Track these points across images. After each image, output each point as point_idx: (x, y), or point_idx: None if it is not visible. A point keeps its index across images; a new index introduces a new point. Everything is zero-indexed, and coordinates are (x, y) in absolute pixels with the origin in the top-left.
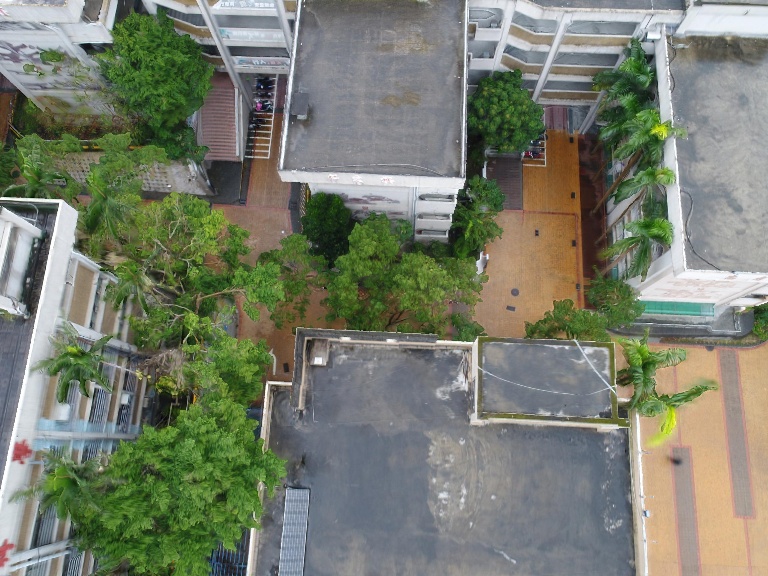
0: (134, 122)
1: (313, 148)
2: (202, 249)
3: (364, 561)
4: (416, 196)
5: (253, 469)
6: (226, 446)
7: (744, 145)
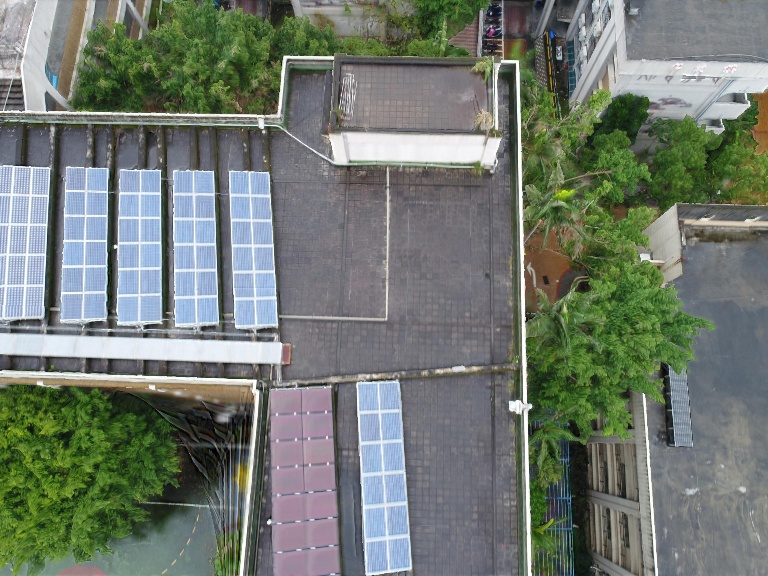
0: (389, 42)
1: (649, 41)
2: (583, 128)
3: (748, 425)
4: (719, 96)
5: (676, 326)
6: (668, 299)
7: None
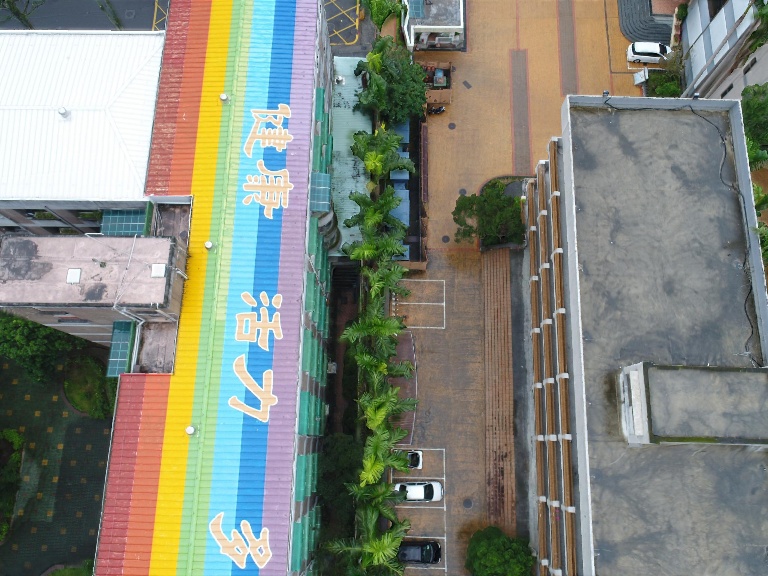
0: None
1: None
2: None
3: None
4: None
5: None
6: None
7: (669, 235)
